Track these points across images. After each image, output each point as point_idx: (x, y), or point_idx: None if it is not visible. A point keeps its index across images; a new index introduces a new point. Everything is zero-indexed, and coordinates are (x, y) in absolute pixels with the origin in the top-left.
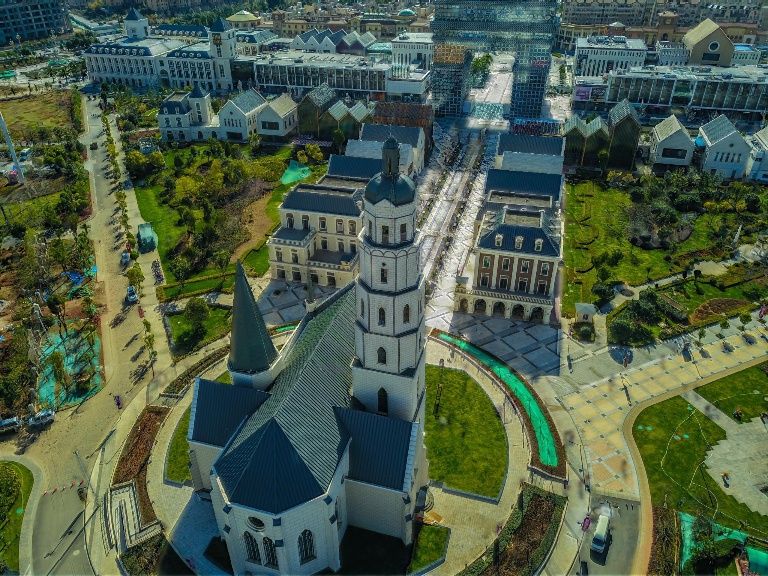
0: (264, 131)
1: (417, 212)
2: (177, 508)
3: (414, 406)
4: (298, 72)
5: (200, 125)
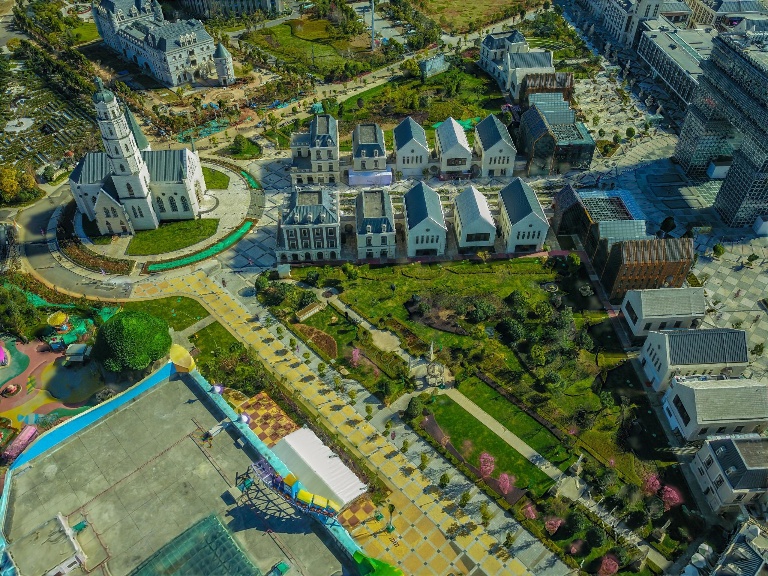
0: None
1: None
2: None
3: (124, 193)
4: (660, 56)
5: (496, 63)
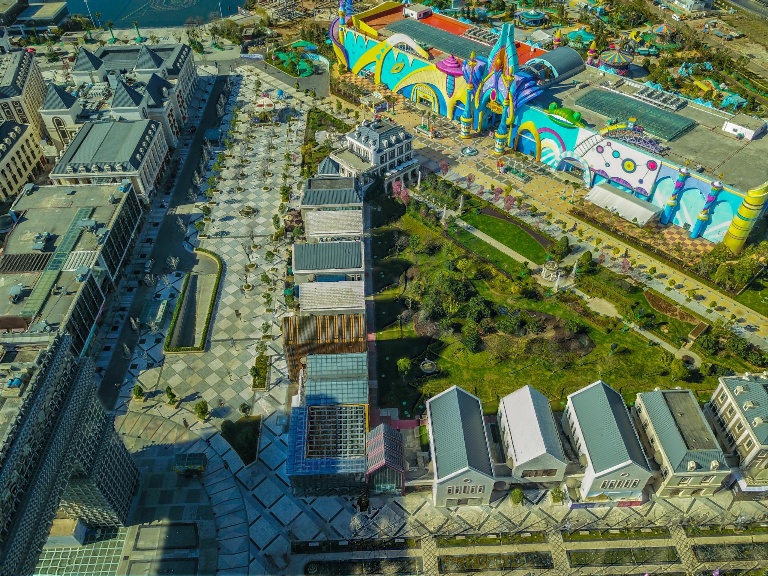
0: None
1: (693, 572)
2: None
3: None
4: None
5: None
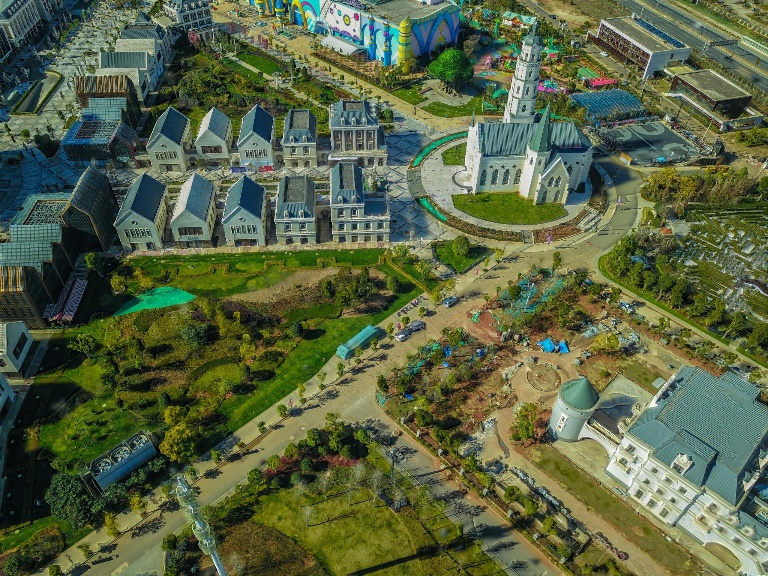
0: (20, 360)
1: None
2: (575, 207)
3: None
4: None
5: None
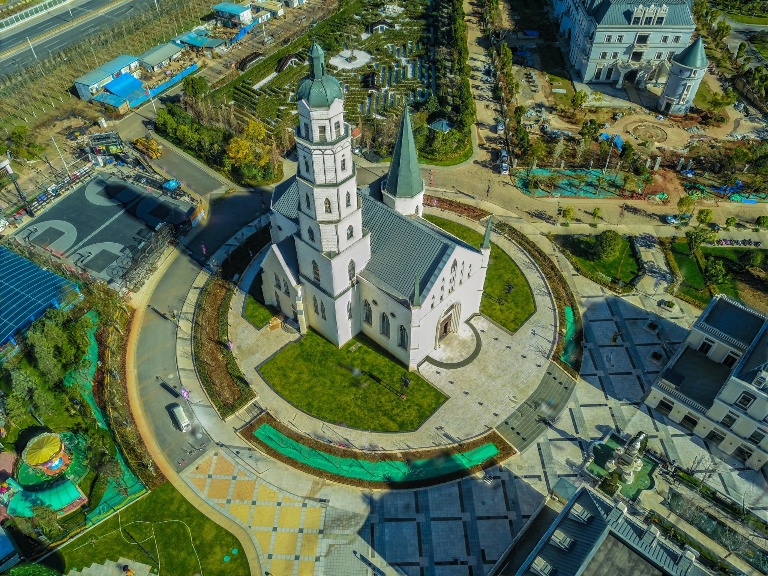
0: None
1: None
2: None
3: None
4: None
5: None
